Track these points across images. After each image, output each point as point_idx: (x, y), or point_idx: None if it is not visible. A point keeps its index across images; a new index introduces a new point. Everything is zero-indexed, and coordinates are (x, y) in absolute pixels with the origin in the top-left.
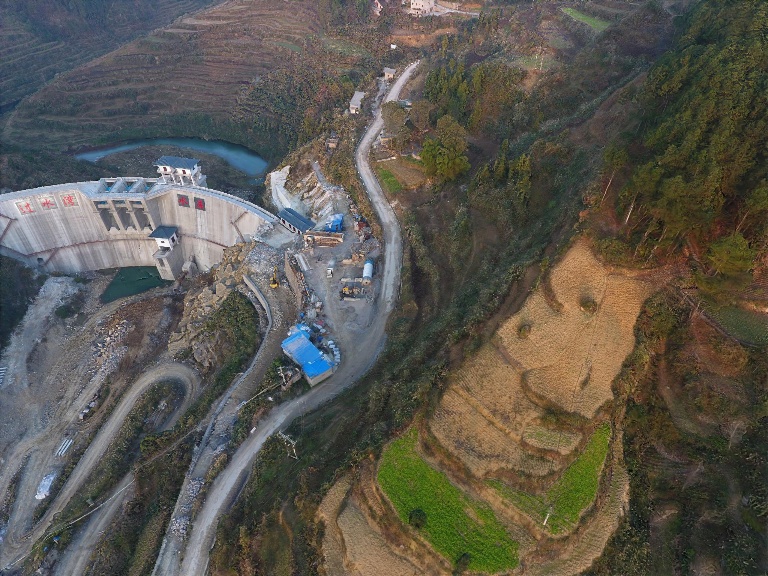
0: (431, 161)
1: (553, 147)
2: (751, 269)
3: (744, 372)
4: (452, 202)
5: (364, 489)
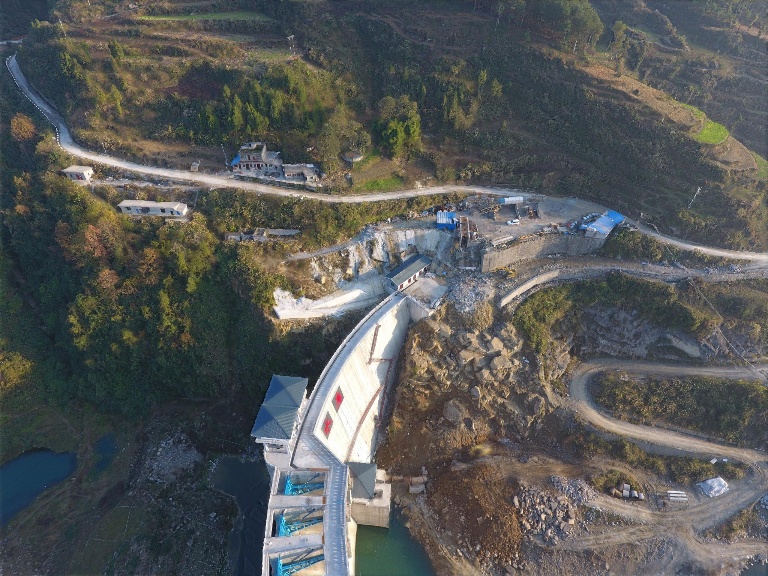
0: (404, 137)
1: (459, 67)
2: None
3: (623, 66)
4: (446, 143)
5: (718, 152)
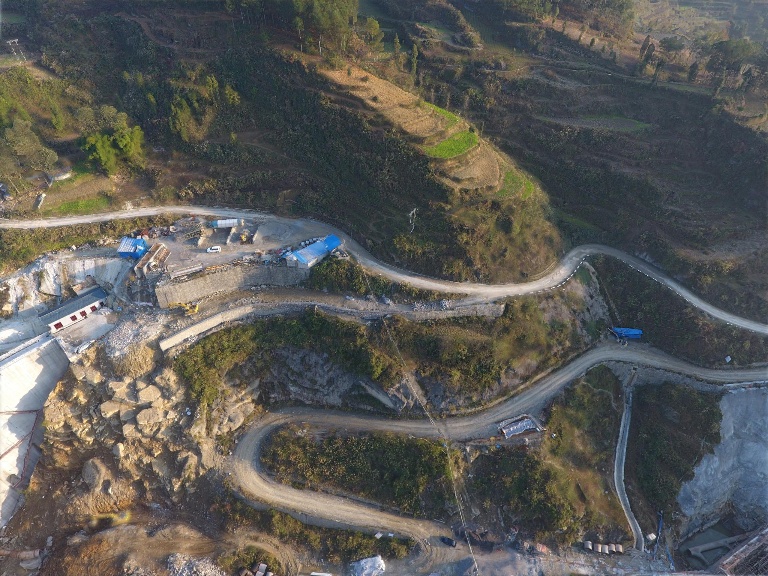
0: (112, 152)
1: (196, 72)
2: (352, 46)
3: None
4: (175, 158)
5: (449, 167)
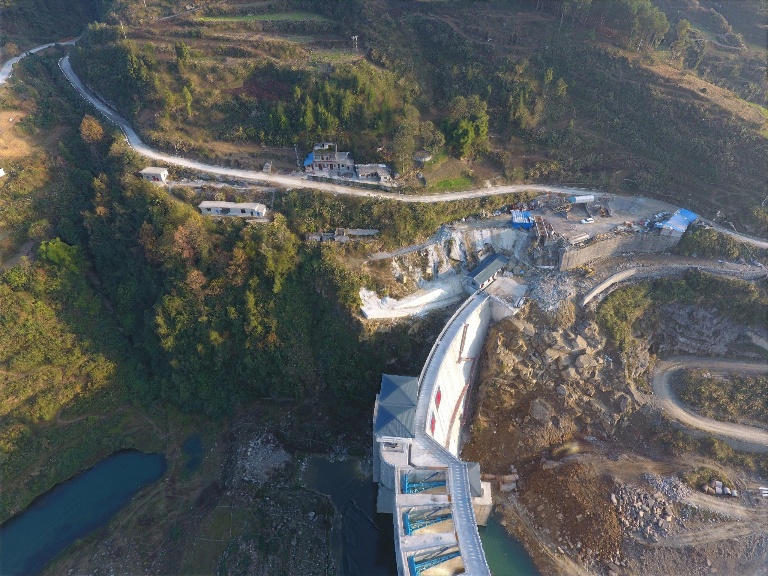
0: None
1: (523, 66)
2: None
3: None
4: (512, 143)
5: None
